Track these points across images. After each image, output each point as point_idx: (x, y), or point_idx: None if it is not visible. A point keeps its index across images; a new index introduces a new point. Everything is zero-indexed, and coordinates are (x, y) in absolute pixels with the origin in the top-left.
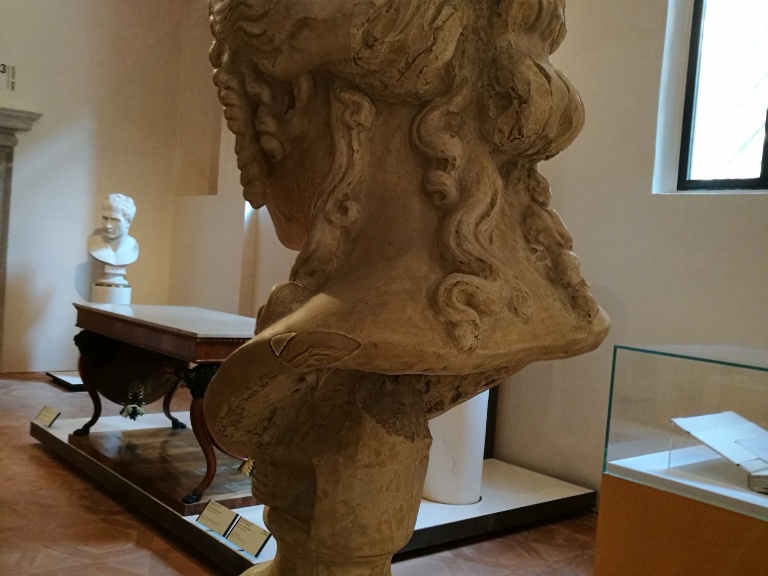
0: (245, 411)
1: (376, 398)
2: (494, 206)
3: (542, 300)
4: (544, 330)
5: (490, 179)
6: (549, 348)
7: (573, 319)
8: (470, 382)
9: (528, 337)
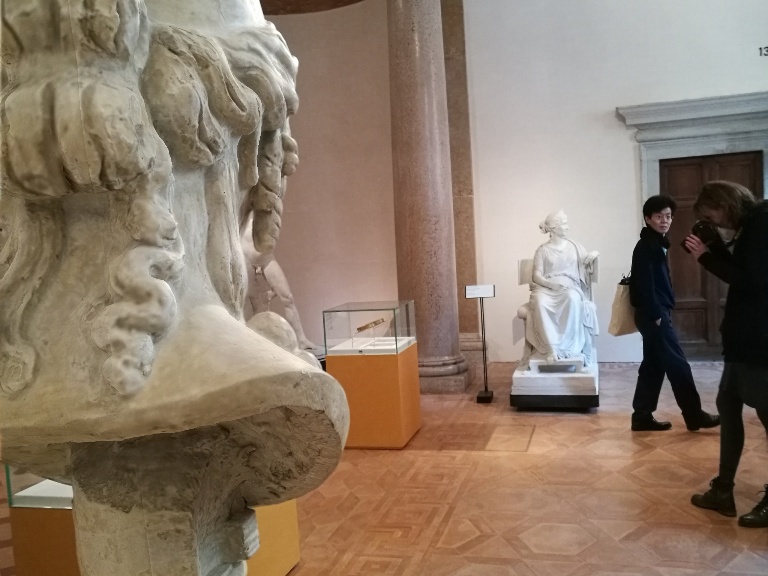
0: (11, 459)
1: (95, 460)
2: (10, 265)
3: (62, 369)
4: (36, 407)
5: (14, 235)
6: (44, 429)
7: (96, 393)
8: (298, 449)
9: (5, 416)
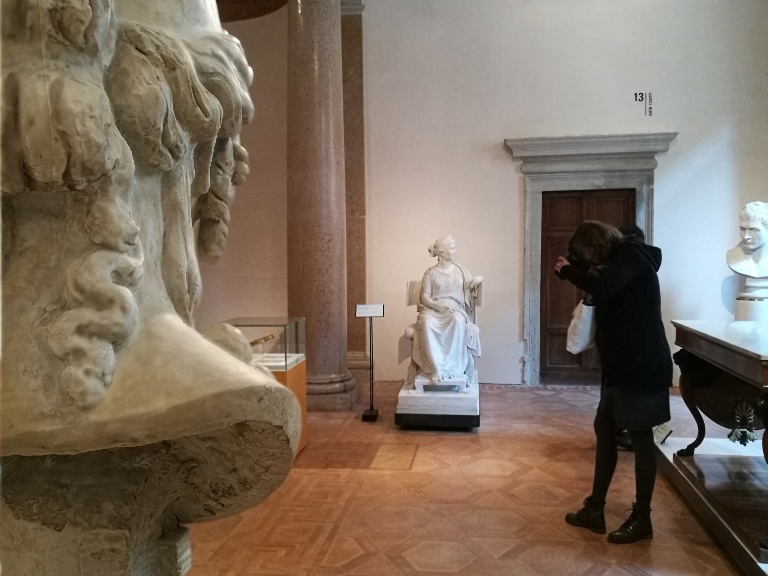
0: None
1: (24, 475)
2: None
3: (12, 377)
4: None
5: None
6: None
7: (51, 403)
8: (244, 465)
9: None
